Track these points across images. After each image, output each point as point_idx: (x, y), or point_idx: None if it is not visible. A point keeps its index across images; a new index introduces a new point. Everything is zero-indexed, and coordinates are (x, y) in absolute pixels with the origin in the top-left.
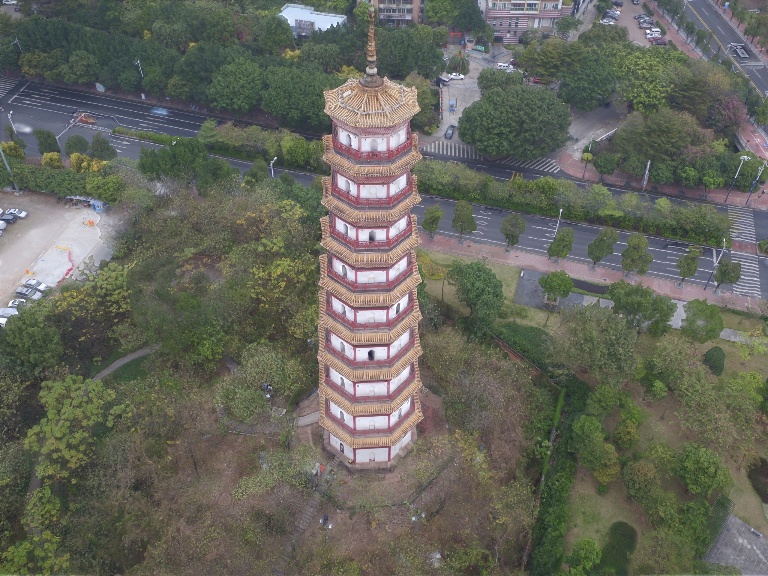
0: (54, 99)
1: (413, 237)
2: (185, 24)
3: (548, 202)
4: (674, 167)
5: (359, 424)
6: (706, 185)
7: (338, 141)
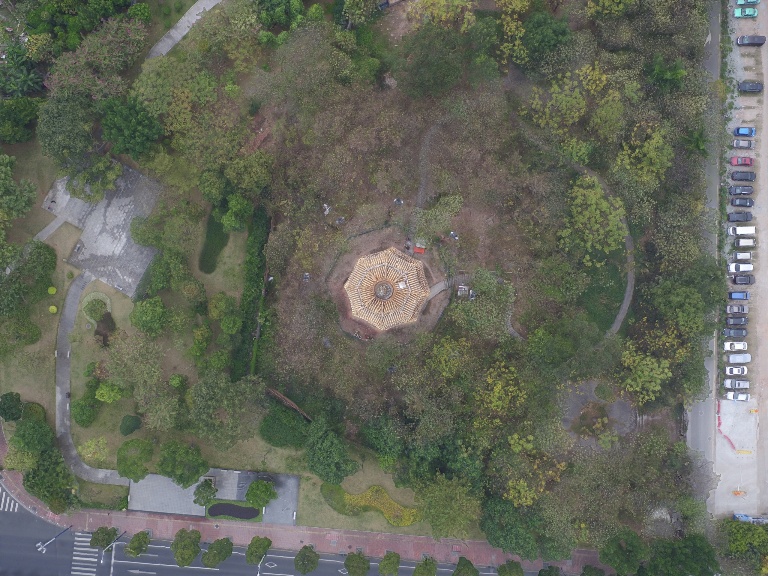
0: None
1: None
2: None
3: None
4: None
5: None
6: None
7: None
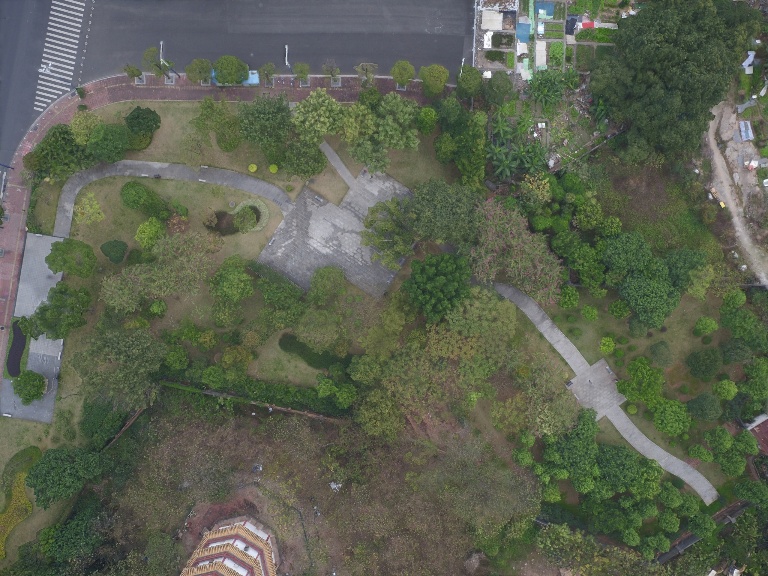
0: None
1: None
2: None
3: None
4: None
5: None
6: None
7: None
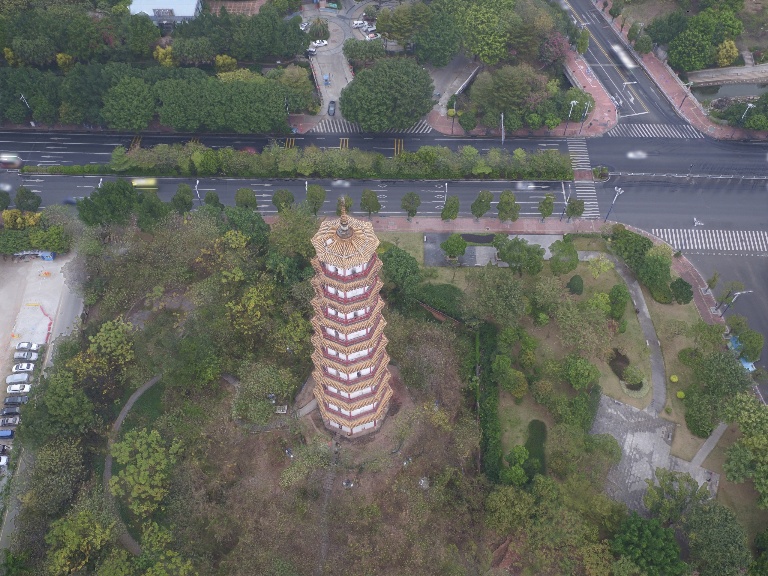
0: None
1: (379, 302)
2: (46, 37)
3: (431, 169)
4: (522, 114)
5: (353, 412)
6: (548, 126)
7: (327, 270)
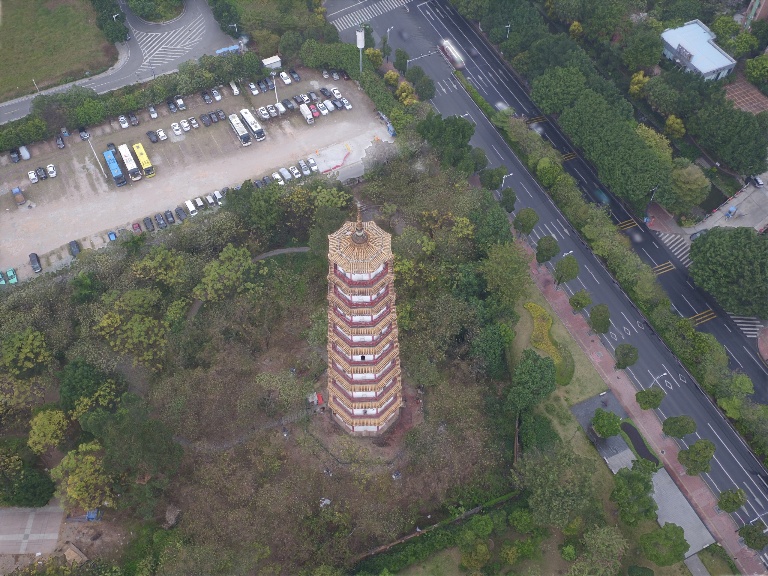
0: (445, 20)
1: (375, 329)
2: (581, 3)
3: (691, 357)
4: None
5: None
6: None
7: None
